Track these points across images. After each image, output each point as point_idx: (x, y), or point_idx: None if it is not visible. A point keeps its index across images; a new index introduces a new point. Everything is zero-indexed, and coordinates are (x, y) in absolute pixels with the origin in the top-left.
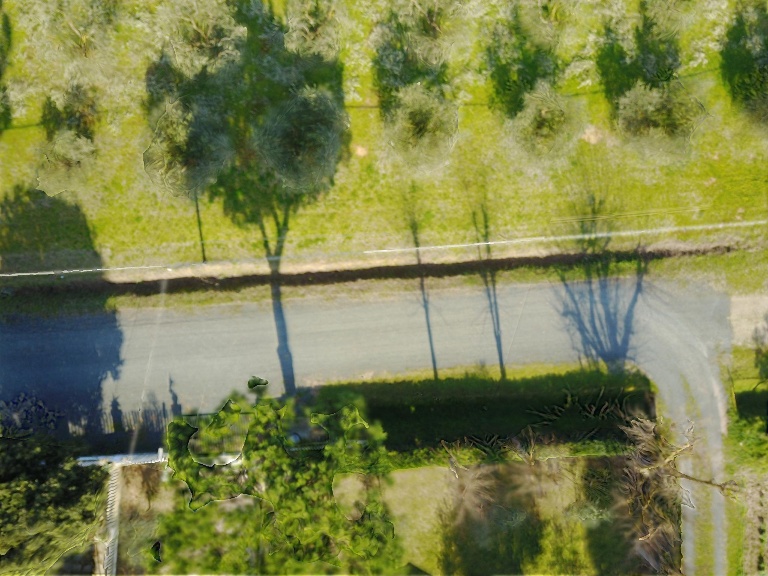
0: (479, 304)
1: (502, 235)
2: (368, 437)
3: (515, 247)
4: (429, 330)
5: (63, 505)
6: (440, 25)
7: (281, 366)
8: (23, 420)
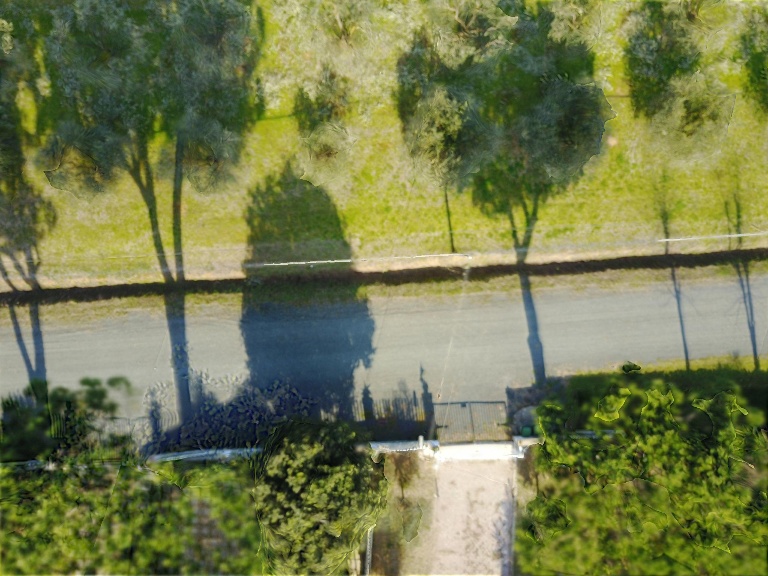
0: (732, 294)
1: (755, 225)
2: (623, 427)
3: (767, 237)
4: (681, 320)
5: (374, 489)
6: (697, 13)
7: (531, 356)
8: (277, 407)
